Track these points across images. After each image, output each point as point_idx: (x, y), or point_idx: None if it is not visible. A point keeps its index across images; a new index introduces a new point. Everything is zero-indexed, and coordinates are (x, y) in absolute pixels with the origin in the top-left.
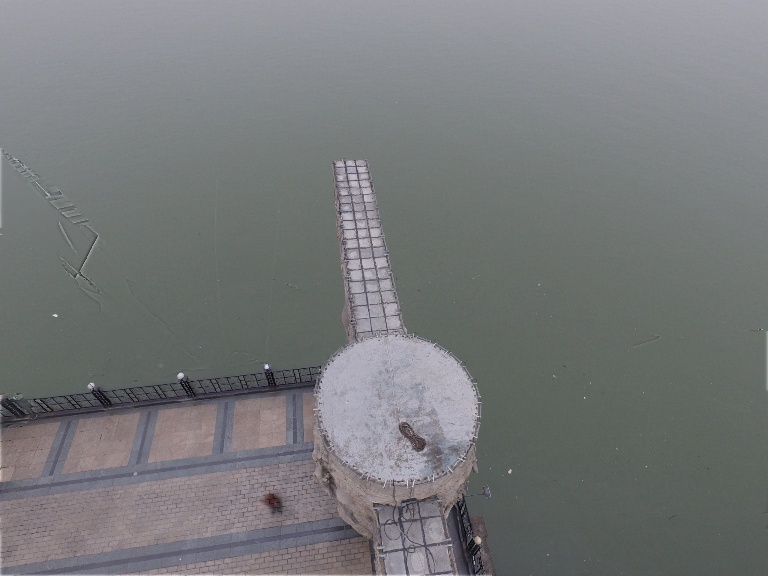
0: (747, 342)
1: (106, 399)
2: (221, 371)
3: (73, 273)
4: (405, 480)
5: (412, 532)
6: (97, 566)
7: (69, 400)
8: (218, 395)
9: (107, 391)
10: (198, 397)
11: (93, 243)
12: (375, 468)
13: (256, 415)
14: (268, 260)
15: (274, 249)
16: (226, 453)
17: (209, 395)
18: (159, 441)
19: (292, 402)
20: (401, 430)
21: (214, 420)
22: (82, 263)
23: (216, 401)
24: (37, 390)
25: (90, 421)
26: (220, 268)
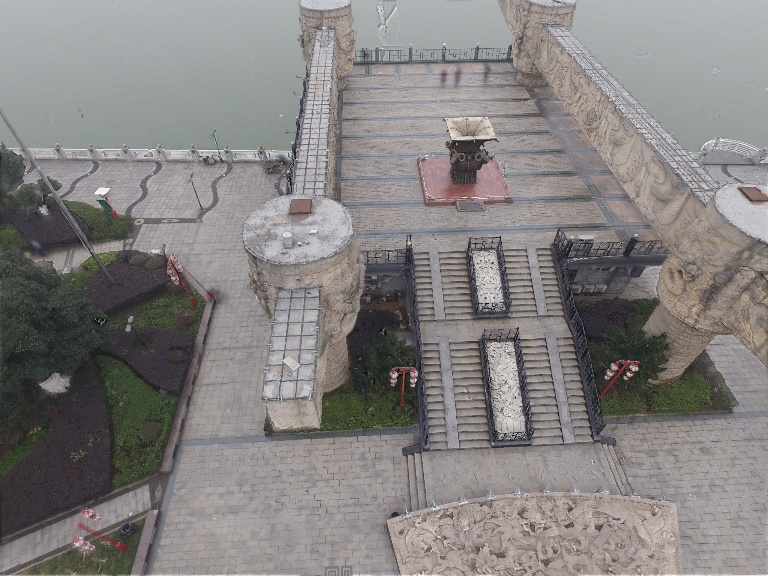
0: (690, 59)
1: (411, 56)
2: (458, 46)
3: (379, 25)
4: (556, 5)
5: (556, 27)
6: (428, 87)
7: (399, 54)
8: (454, 61)
9: (415, 50)
10: (446, 61)
11: (396, 5)
12: (547, 4)
13: (471, 66)
14: (464, 25)
15: (468, 18)
16: (463, 72)
17: (450, 61)
18: (435, 69)
19: (485, 64)
20: (553, 1)
21: (454, 66)
22: (390, 14)
23: (453, 63)
24: (389, 47)
25: (404, 65)
26: (440, 30)
